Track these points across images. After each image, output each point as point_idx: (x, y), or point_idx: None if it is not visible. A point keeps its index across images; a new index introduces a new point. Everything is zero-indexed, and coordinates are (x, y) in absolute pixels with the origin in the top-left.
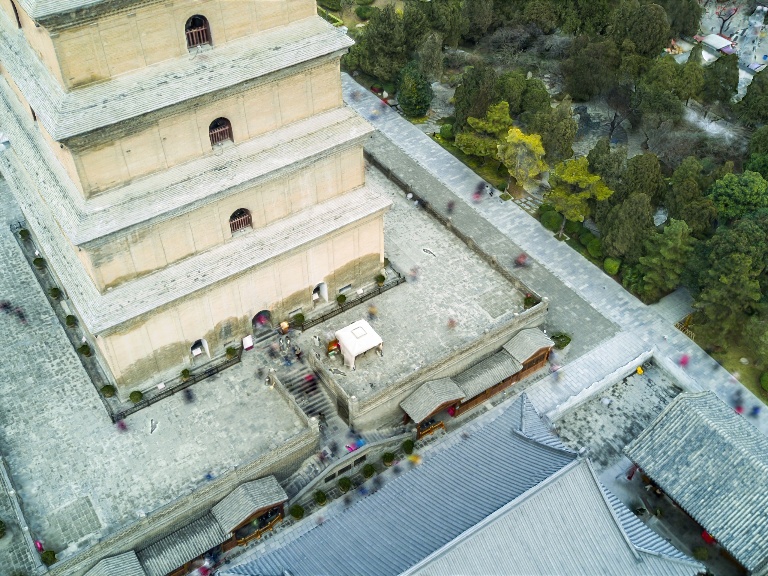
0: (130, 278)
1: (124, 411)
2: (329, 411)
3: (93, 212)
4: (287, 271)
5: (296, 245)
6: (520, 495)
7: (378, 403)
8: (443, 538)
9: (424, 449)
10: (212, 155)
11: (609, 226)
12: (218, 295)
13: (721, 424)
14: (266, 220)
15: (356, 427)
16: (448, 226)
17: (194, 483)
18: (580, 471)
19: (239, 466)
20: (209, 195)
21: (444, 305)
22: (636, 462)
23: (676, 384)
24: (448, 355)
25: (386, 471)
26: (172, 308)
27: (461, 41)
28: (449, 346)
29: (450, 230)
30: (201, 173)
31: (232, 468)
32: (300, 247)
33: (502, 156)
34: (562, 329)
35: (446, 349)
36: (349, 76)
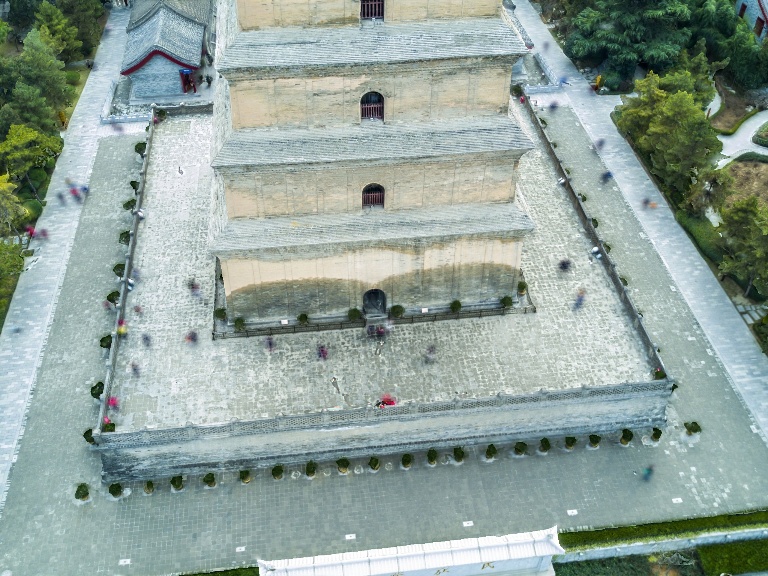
0: None
1: None
2: None
3: None
4: None
5: None
6: None
7: None
8: None
9: None
10: None
11: None
12: None
13: None
14: None
15: None
16: None
17: None
18: None
19: None
20: None
21: None
22: None
23: None
24: None
25: None
26: None
27: None
28: None
29: None
30: None
31: None
32: None
33: (23, 208)
34: None
35: None
36: None
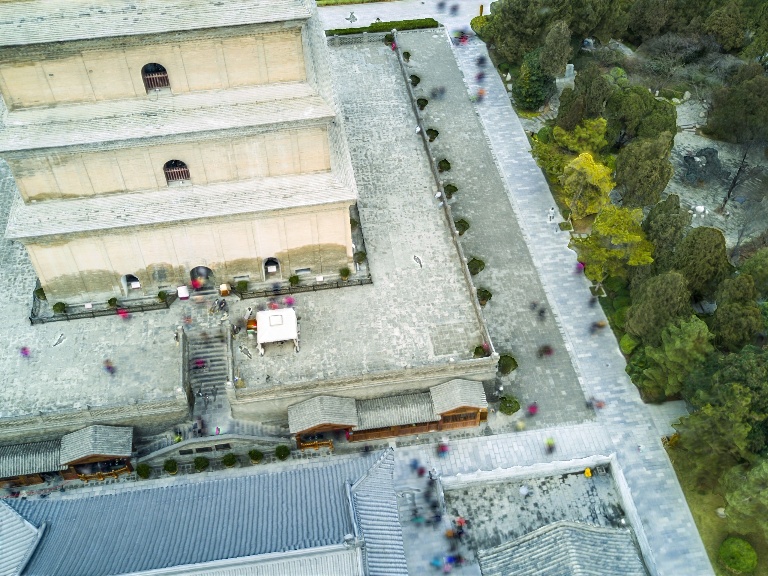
0: (55, 197)
1: (46, 317)
2: (224, 387)
3: (12, 125)
4: (229, 235)
5: (233, 212)
6: (259, 554)
7: (261, 398)
8: (169, 561)
9: (300, 461)
10: (146, 99)
11: (638, 297)
12: (148, 238)
13: (595, 574)
14: (207, 178)
15: (236, 413)
16: (454, 239)
17: (56, 406)
18: (348, 557)
19: (94, 407)
20: (131, 138)
21: (394, 322)
22: (483, 572)
23: (621, 505)
24: (354, 376)
25: (250, 467)
26: (96, 237)
27: (631, 37)
28: (369, 367)
29: (455, 244)
30: (129, 114)
31: (85, 407)
32: (240, 215)
33: (563, 180)
34: (526, 393)
35: (364, 369)
36: (486, 47)
